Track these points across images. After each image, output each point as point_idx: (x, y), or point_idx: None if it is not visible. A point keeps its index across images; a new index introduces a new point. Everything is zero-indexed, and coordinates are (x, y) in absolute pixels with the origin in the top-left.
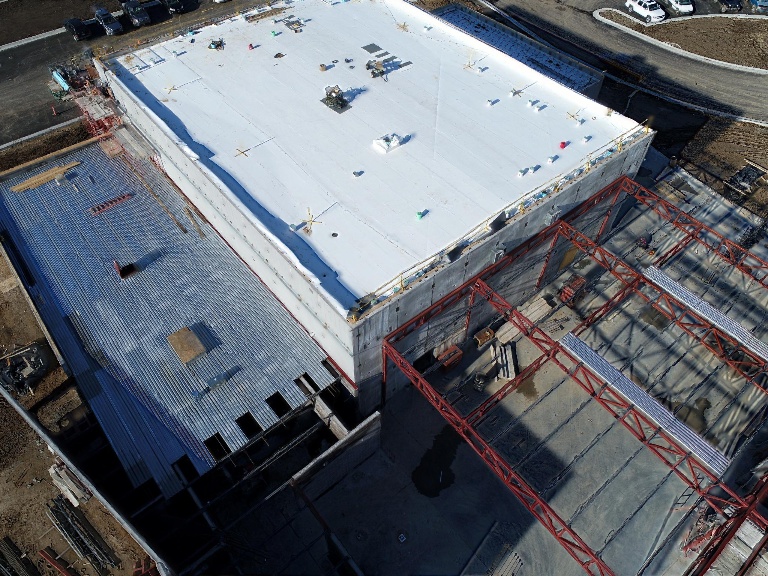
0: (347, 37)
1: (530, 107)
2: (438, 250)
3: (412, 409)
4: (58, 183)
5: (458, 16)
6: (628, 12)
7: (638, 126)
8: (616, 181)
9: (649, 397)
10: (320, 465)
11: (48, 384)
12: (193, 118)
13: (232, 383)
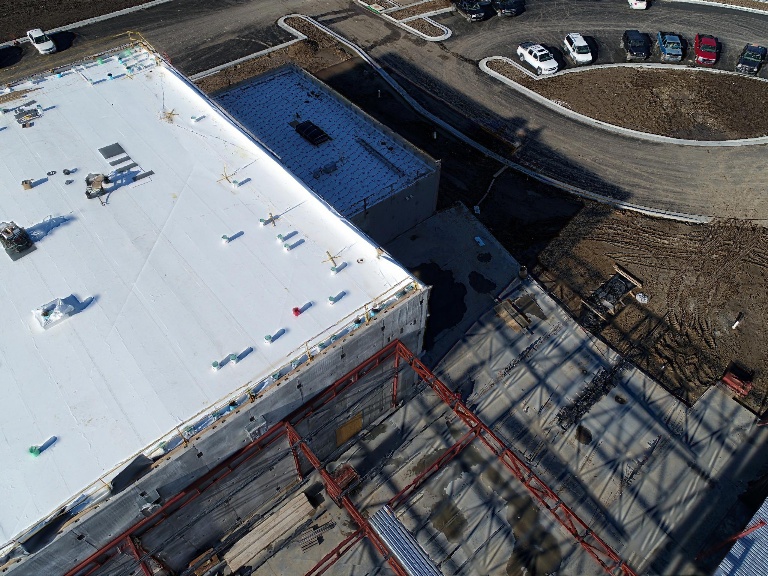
0: (87, 133)
1: (280, 244)
2: (36, 519)
3: None
4: None
5: (292, 80)
6: (519, 61)
7: None
8: (382, 350)
9: None
10: None
11: None
12: None
13: None
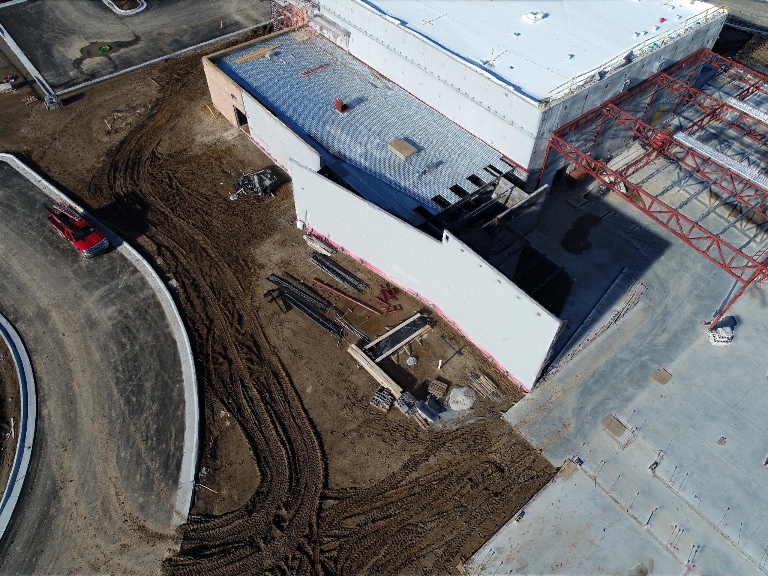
0: None
1: None
2: (587, 76)
3: (553, 208)
4: (269, 57)
5: None
6: None
7: (716, 8)
8: (699, 51)
9: (740, 164)
10: (511, 215)
11: (283, 192)
12: (382, 2)
13: (440, 170)
